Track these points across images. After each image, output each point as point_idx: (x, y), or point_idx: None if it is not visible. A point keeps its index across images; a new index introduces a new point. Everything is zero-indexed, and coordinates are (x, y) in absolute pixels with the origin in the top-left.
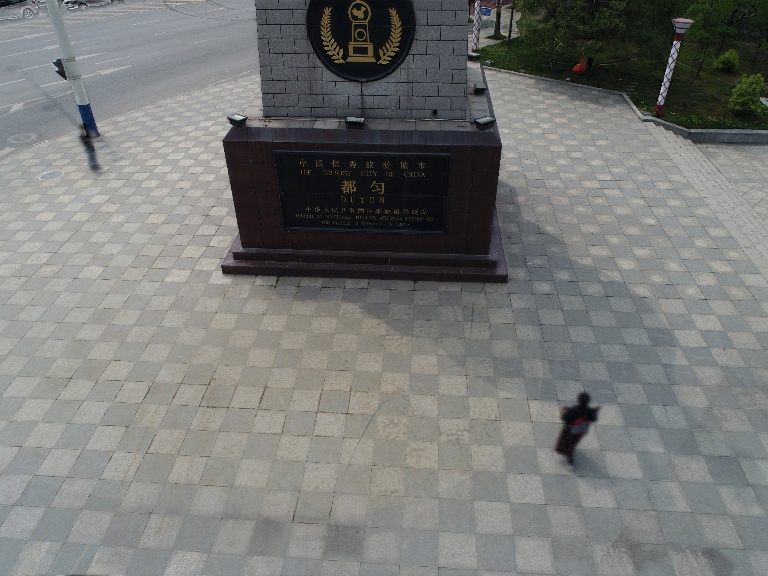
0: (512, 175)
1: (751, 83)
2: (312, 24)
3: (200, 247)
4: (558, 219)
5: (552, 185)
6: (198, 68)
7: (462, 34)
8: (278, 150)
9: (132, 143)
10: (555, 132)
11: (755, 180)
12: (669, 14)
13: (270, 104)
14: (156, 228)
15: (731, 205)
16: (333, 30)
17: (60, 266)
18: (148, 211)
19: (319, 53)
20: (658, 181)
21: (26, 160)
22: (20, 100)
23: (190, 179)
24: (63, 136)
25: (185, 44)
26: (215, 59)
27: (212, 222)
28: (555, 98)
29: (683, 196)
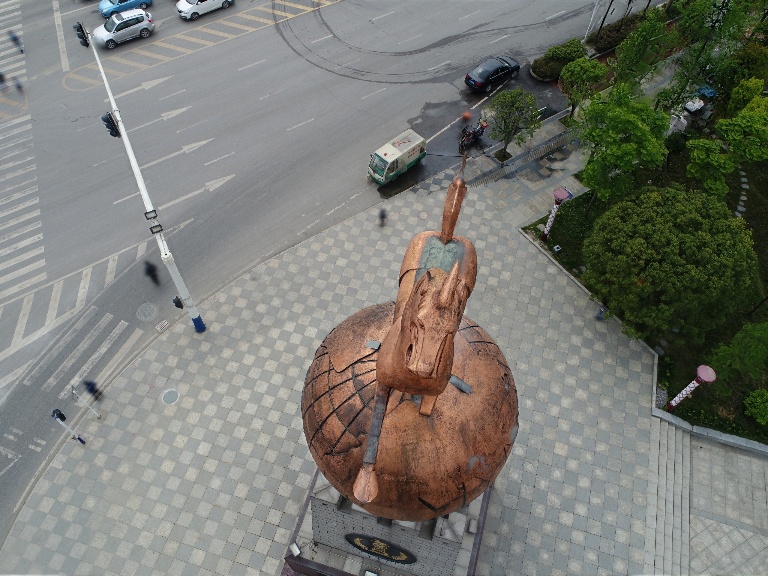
0: (510, 487)
1: (766, 400)
2: (348, 537)
3: (268, 541)
4: (523, 567)
5: (536, 512)
6: (292, 192)
7: (447, 572)
8: (319, 571)
9: (230, 352)
10: (569, 417)
11: (715, 516)
12: (719, 310)
13: (318, 540)
14: (241, 505)
15: (667, 569)
16: (362, 543)
17: (178, 544)
18: (236, 478)
19: (352, 543)
20: (621, 528)
21: (152, 363)
22: (144, 236)
23: (269, 432)
24: (178, 322)
25: (285, 130)
26: (309, 173)
27: (279, 506)
28: (592, 346)
29: (630, 558)
